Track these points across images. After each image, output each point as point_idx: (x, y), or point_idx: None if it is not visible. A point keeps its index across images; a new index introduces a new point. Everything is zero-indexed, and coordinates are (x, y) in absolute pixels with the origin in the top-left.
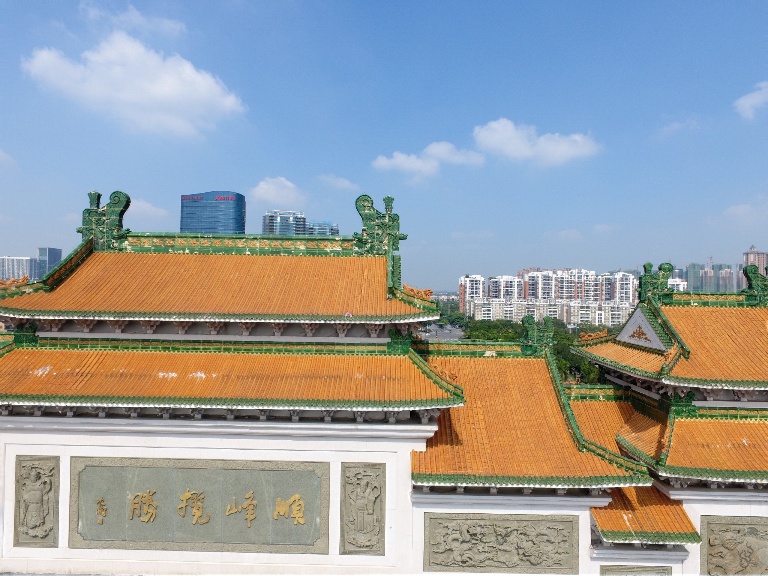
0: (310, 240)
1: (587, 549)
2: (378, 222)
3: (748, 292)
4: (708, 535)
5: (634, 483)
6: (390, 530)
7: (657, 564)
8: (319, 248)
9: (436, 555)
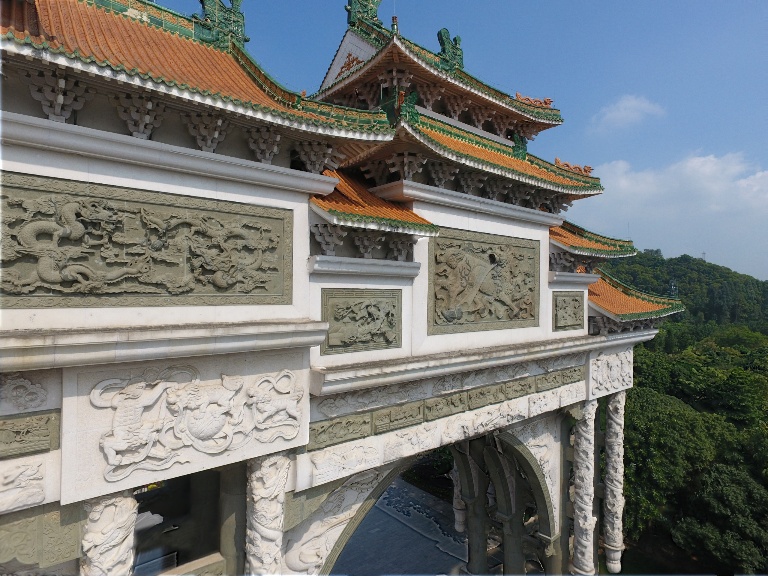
0: None
1: (304, 263)
2: None
3: (442, 55)
4: (435, 250)
5: (372, 134)
6: None
7: (387, 286)
8: None
9: None
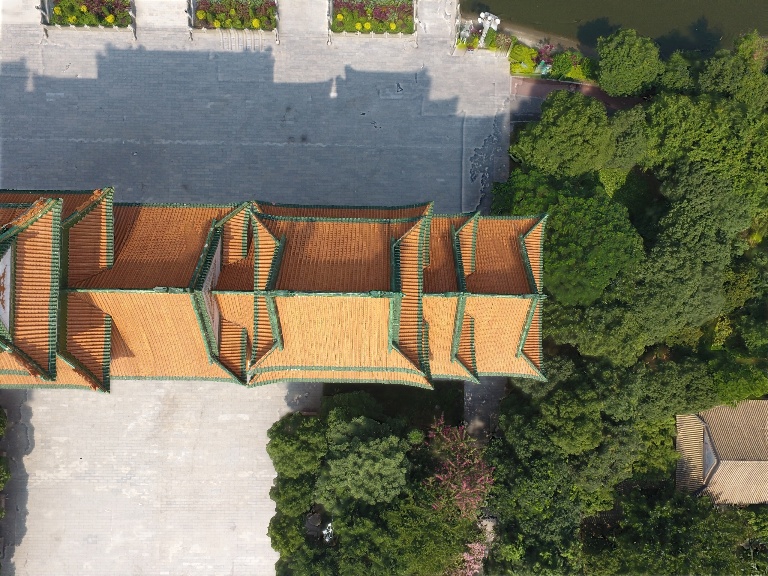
0: None
1: None
2: None
3: None
4: None
5: None
6: None
7: None
8: None
9: None
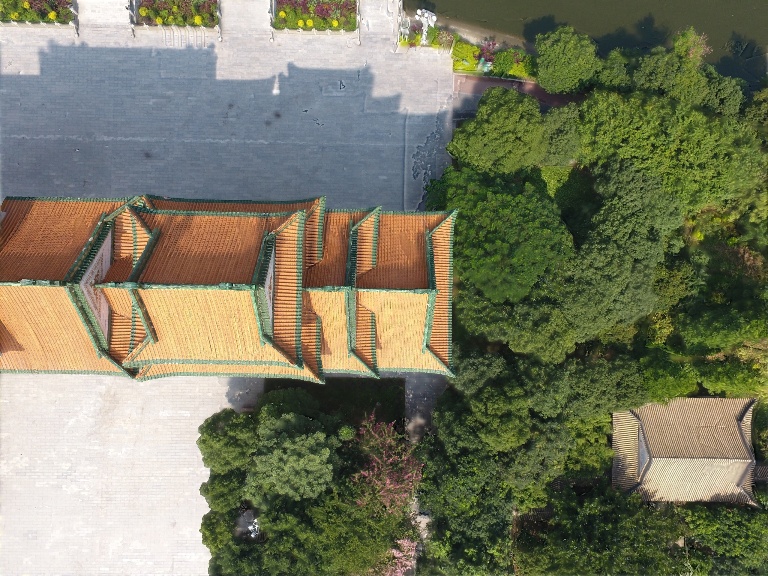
0: None
1: None
2: None
3: None
4: None
5: None
6: None
7: None
8: None
9: None
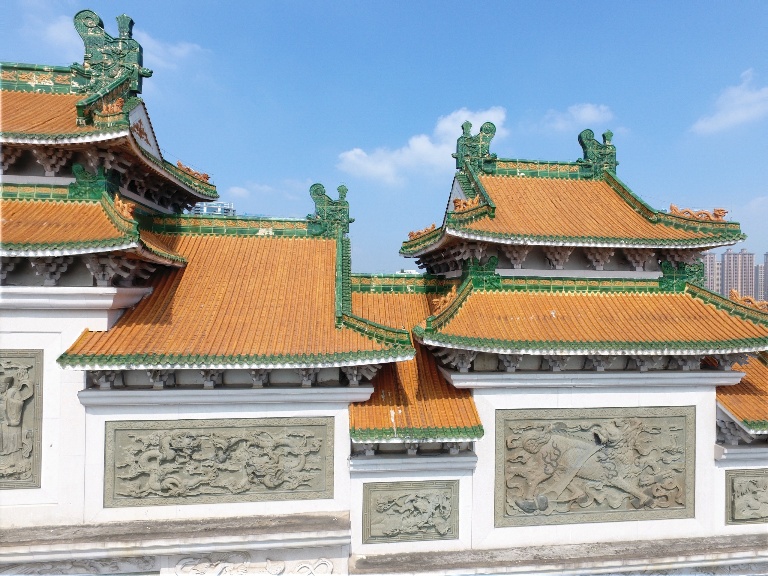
0: (5, 69)
1: (345, 462)
2: (107, 49)
3: (582, 161)
4: (506, 435)
5: (391, 357)
6: (50, 449)
7: (440, 477)
8: (19, 81)
9: (124, 483)
